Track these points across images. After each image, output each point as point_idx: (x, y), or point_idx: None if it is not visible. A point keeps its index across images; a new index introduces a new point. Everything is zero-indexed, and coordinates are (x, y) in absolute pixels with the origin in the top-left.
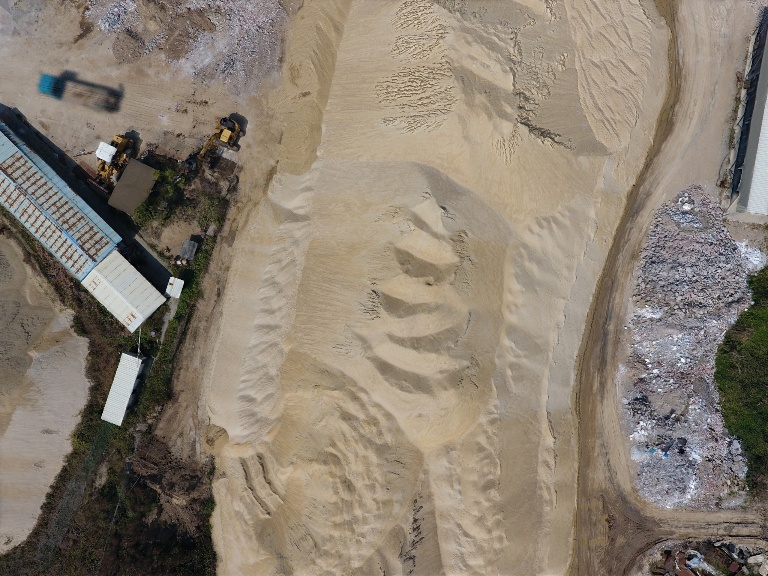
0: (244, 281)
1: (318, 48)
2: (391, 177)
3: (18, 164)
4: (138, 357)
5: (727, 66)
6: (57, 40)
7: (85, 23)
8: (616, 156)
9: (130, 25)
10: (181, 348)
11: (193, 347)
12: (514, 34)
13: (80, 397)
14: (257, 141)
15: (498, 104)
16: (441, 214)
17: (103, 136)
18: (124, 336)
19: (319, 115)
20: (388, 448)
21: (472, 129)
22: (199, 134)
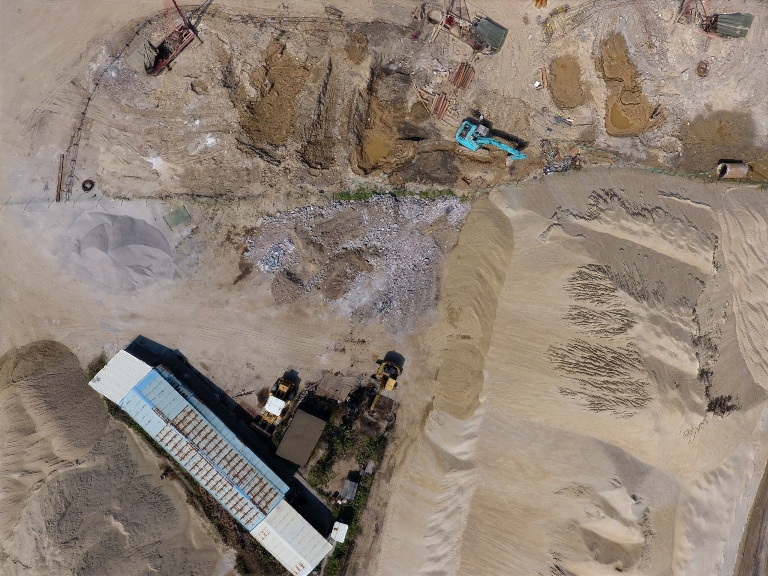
0: (405, 522)
1: (481, 297)
2: (571, 450)
3: (189, 418)
4: None
5: None
6: (217, 281)
7: (244, 264)
8: None
9: (288, 266)
10: None
11: None
12: (696, 315)
13: None
14: (413, 378)
15: (688, 396)
16: (632, 504)
17: (263, 376)
18: (286, 575)
19: (481, 361)
20: None
21: (663, 421)
22: (357, 372)
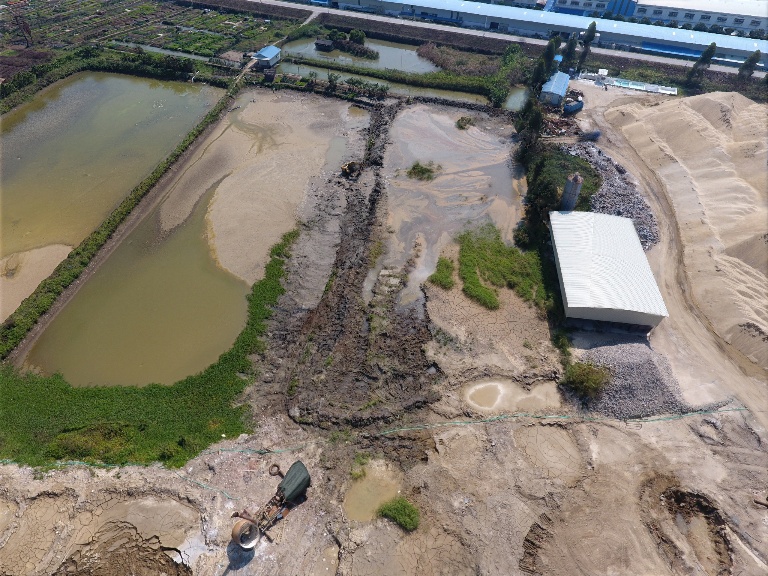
0: None
1: None
2: None
3: None
4: None
5: None
6: None
7: None
8: (717, 252)
9: None
10: None
11: None
12: None
13: None
14: None
15: None
16: None
17: None
18: None
19: None
20: (764, 136)
21: None
22: None
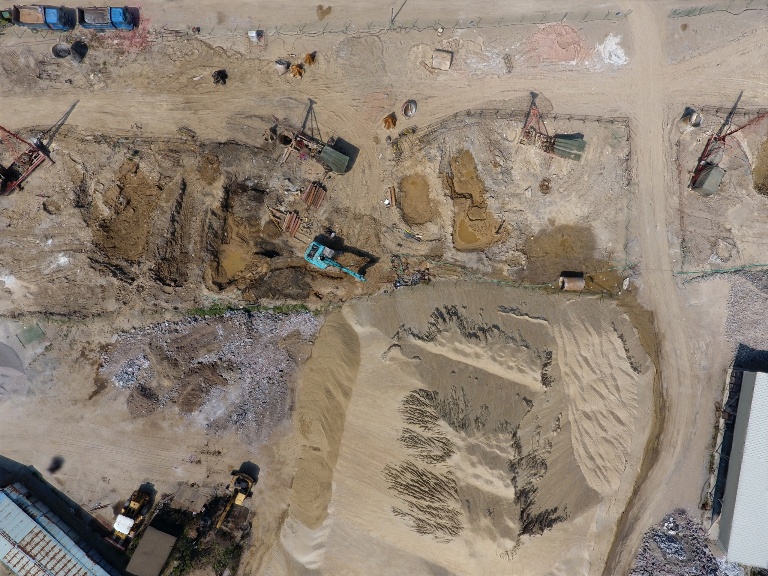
0: None
1: (328, 413)
2: (401, 568)
3: (37, 539)
4: None
5: (706, 397)
6: (72, 397)
7: (99, 379)
8: (607, 500)
9: (144, 380)
10: None
11: None
12: (514, 440)
13: None
14: (269, 487)
15: (501, 522)
16: None
17: (118, 489)
18: None
19: (329, 473)
20: None
21: (478, 547)
22: (213, 483)
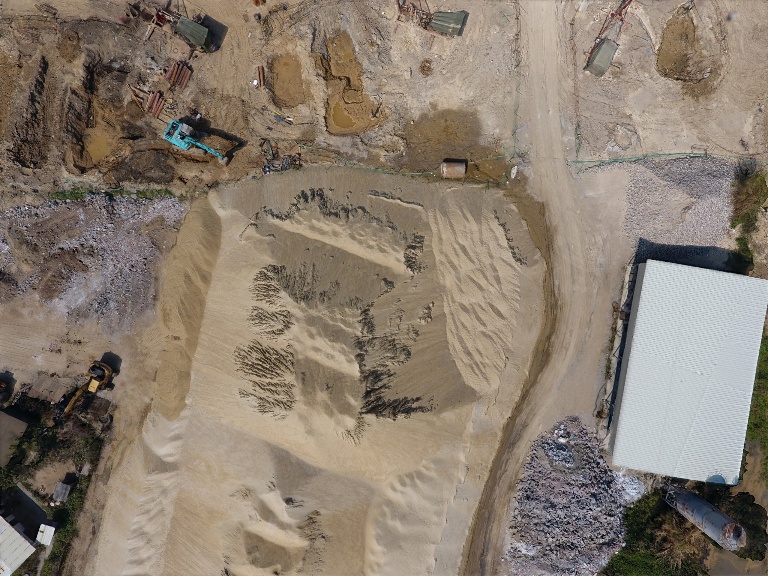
0: (116, 525)
1: (185, 298)
2: (245, 452)
3: None
4: None
5: (603, 296)
6: None
7: None
8: (486, 399)
9: (3, 266)
10: None
11: None
12: (363, 316)
13: None
14: (131, 379)
15: (341, 398)
16: (285, 507)
17: None
18: None
19: (188, 362)
20: None
21: (315, 424)
22: (73, 373)
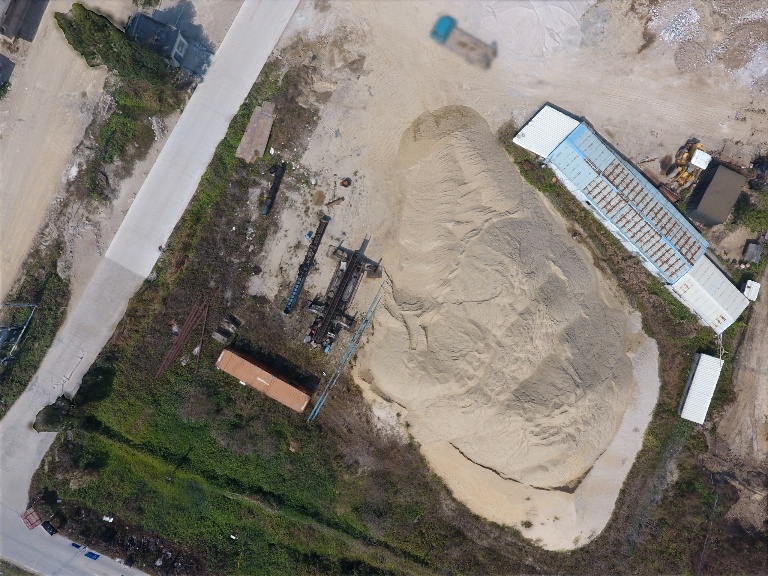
0: None
1: None
2: None
3: (617, 171)
4: (721, 358)
5: None
6: (622, 50)
7: (647, 34)
8: None
9: (691, 35)
10: (740, 349)
11: (750, 348)
12: None
13: (654, 396)
14: None
15: None
16: None
17: (666, 143)
18: (689, 337)
19: None
20: None
21: None
22: (757, 141)
